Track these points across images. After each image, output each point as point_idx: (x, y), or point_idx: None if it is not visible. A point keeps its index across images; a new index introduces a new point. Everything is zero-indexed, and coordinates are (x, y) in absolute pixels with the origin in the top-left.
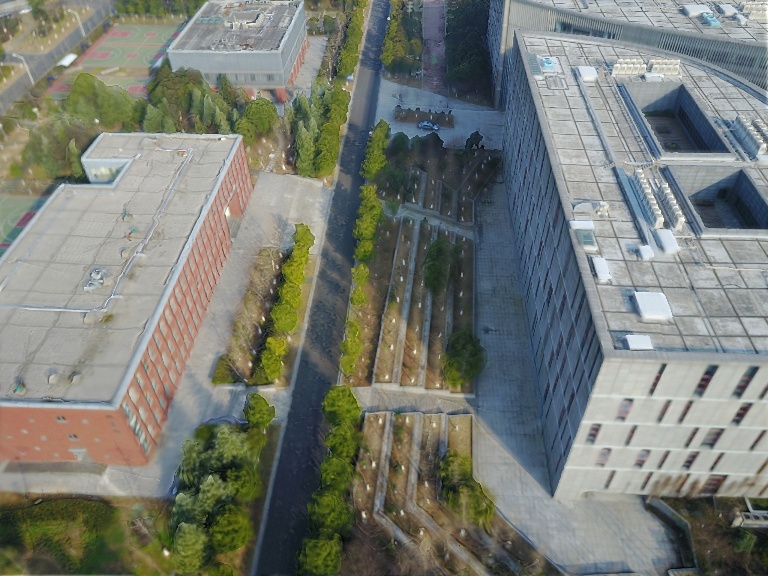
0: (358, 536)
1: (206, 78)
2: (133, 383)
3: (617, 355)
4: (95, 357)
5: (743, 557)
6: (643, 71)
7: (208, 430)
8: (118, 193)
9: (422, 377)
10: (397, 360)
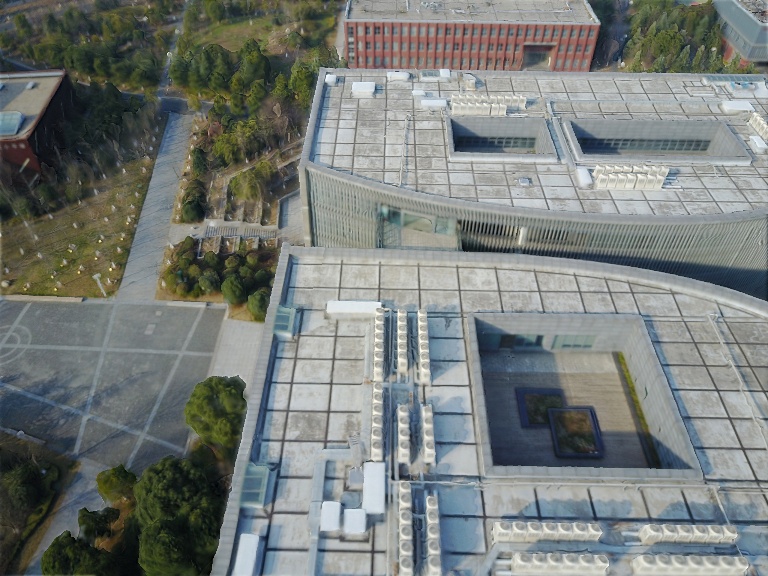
0: (296, 112)
1: (719, 21)
2: (363, 25)
3: (321, 71)
4: None
5: (277, 261)
6: (765, 136)
7: None
8: (512, 0)
9: None
10: None
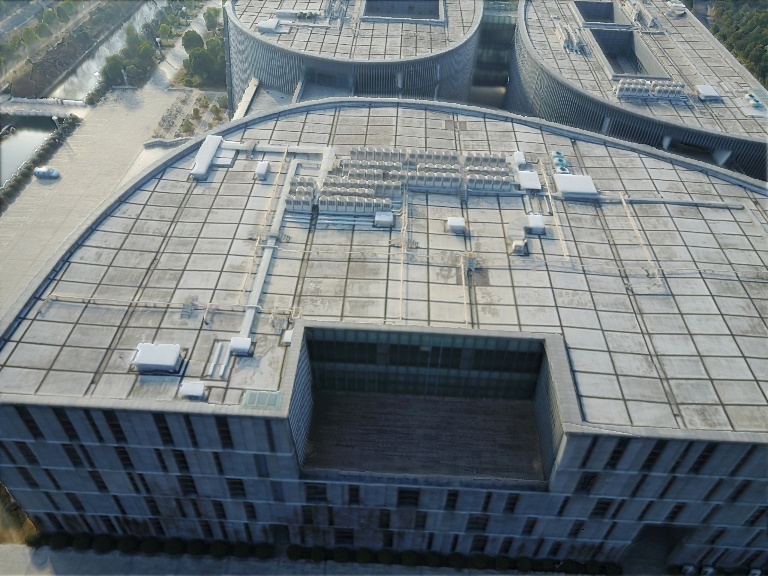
0: None
1: None
2: None
3: None
4: None
5: None
6: None
7: None
8: None
9: None
10: None
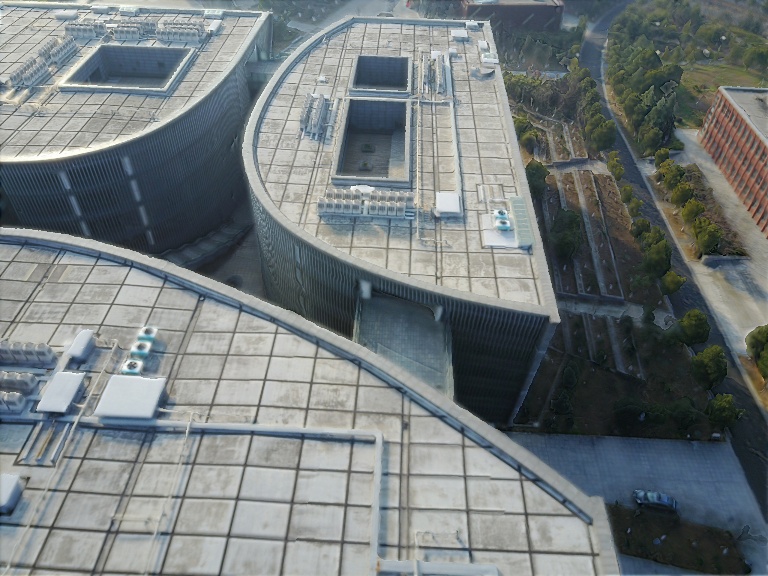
0: (573, 102)
1: None
2: None
3: None
4: (759, 106)
5: None
6: None
7: (676, 144)
8: None
9: (558, 176)
10: (579, 180)
